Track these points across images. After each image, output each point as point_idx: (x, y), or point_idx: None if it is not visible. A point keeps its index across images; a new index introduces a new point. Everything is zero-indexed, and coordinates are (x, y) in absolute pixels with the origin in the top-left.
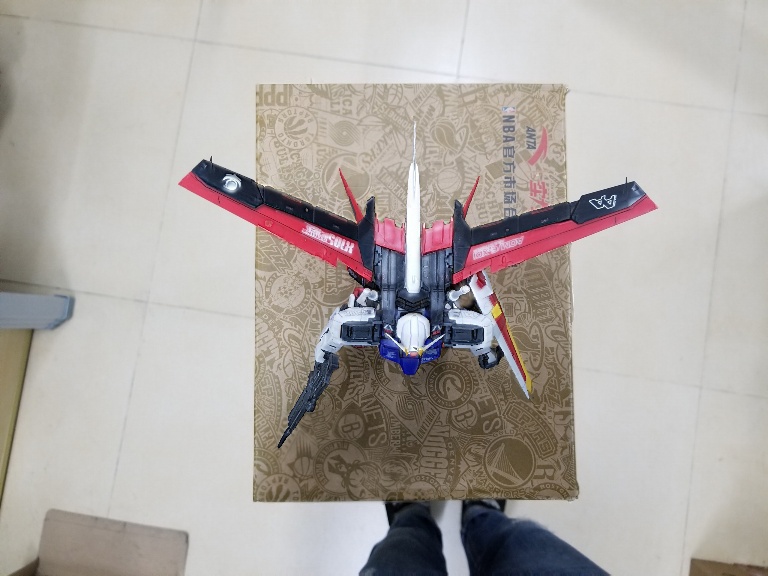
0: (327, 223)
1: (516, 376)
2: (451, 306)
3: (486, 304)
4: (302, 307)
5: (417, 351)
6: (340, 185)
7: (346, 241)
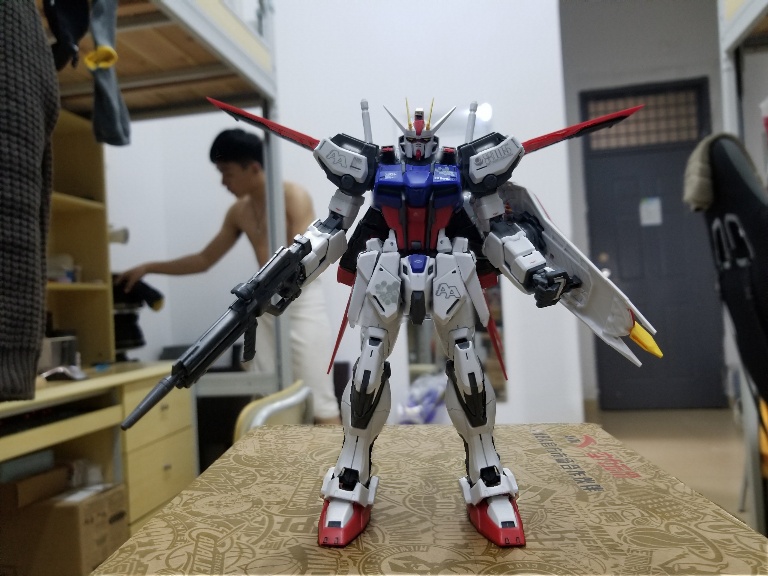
0: None
1: (603, 278)
2: None
3: None
4: (240, 515)
5: (423, 116)
6: None
7: None
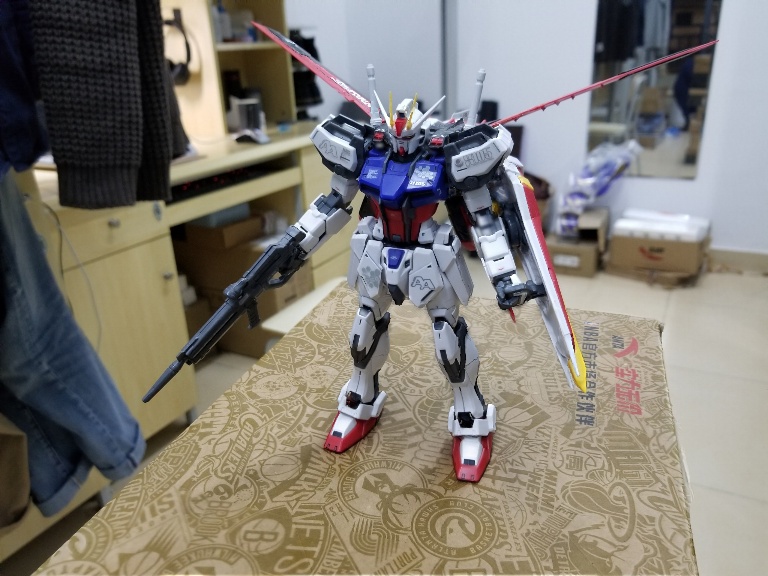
0: None
1: (553, 306)
2: (483, 402)
3: (512, 166)
4: (283, 402)
5: (405, 114)
6: None
7: None
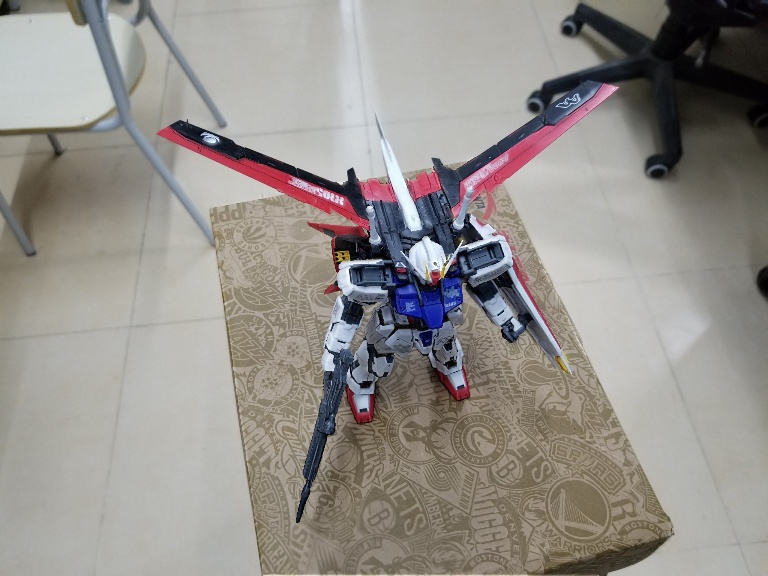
0: (312, 180)
1: (549, 339)
2: None
3: None
4: (292, 395)
5: (438, 269)
6: (308, 273)
7: (335, 195)
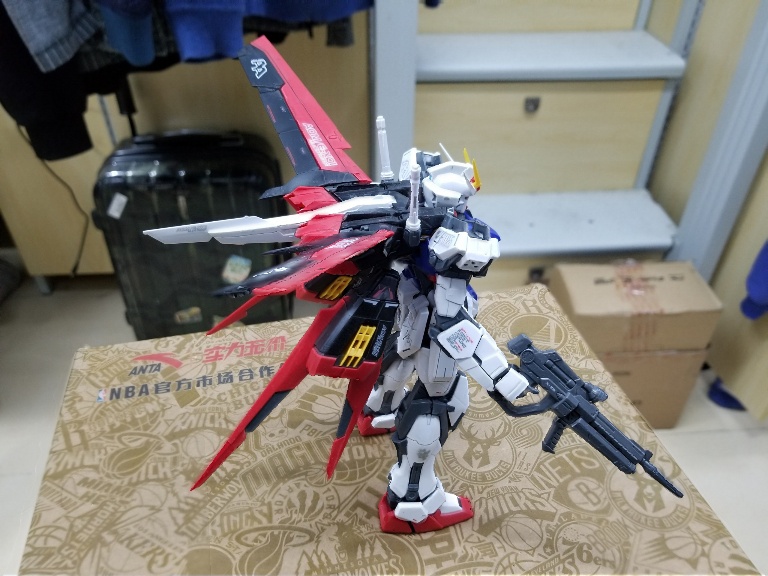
0: None
1: None
2: None
3: None
4: None
5: None
6: None
7: None
